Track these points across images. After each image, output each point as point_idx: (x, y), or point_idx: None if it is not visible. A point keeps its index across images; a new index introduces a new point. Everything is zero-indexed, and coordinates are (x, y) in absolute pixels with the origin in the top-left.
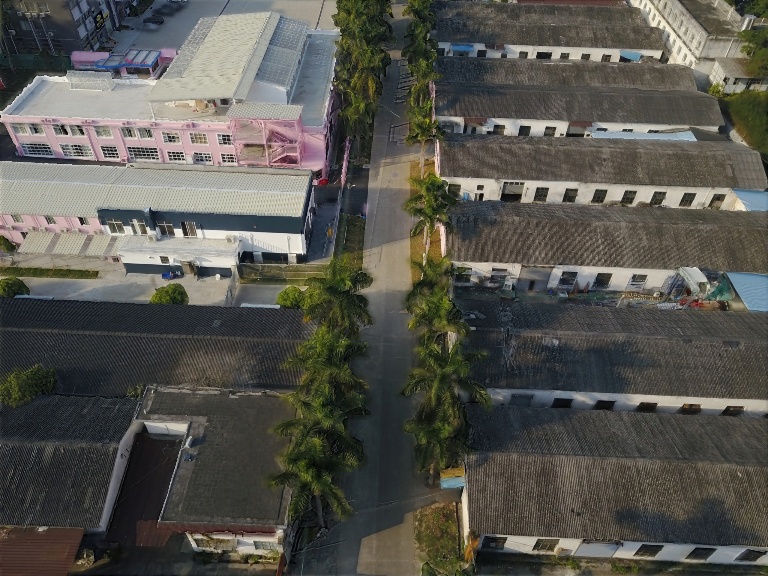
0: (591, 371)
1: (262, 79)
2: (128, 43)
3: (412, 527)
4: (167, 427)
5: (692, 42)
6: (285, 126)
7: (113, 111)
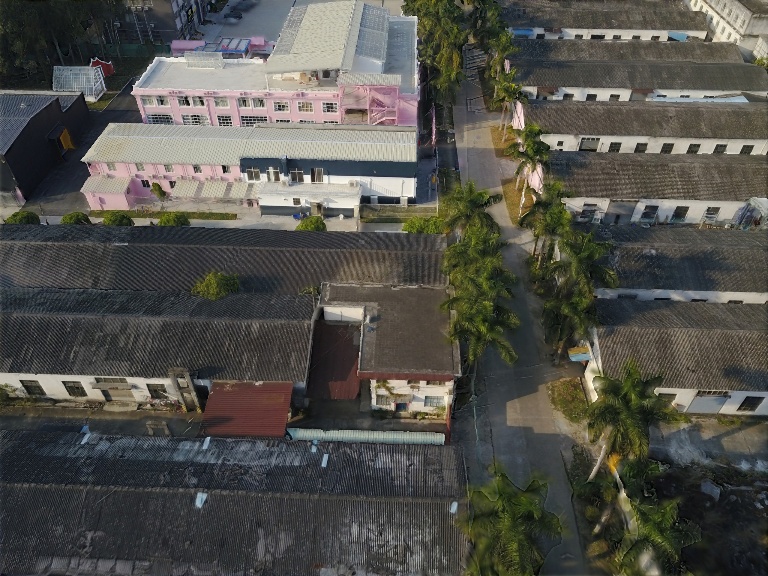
0: (686, 274)
1: (361, 54)
2: (214, 35)
3: (546, 395)
4: (342, 314)
5: (736, 21)
6: (383, 94)
7: (229, 84)
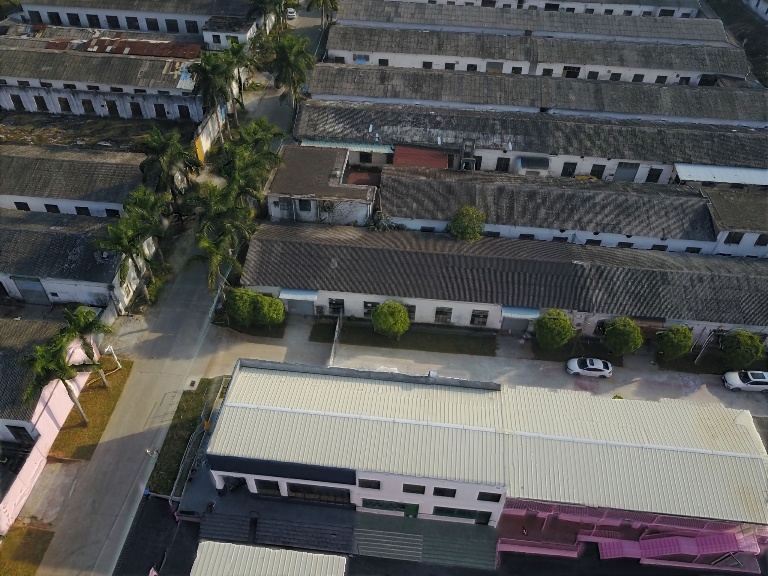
0: None
1: None
2: None
3: None
4: None
5: None
6: None
7: None
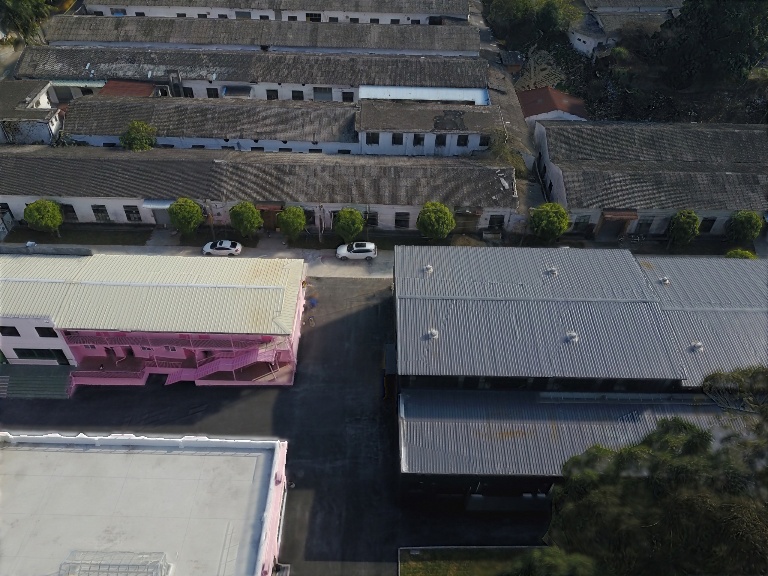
0: None
1: None
2: None
3: None
4: None
5: None
6: None
7: (75, 479)
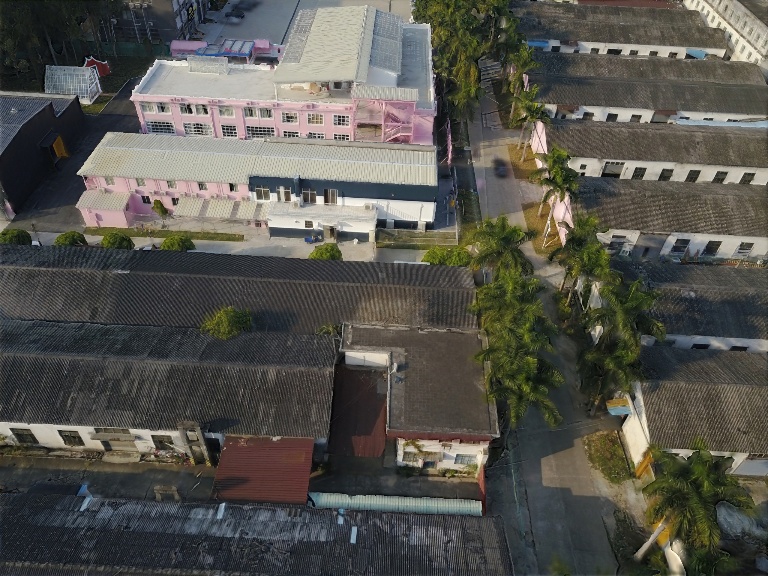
0: (727, 319)
1: (375, 65)
2: (215, 35)
3: (583, 450)
4: (364, 358)
5: (757, 41)
6: (398, 108)
7: (234, 92)
